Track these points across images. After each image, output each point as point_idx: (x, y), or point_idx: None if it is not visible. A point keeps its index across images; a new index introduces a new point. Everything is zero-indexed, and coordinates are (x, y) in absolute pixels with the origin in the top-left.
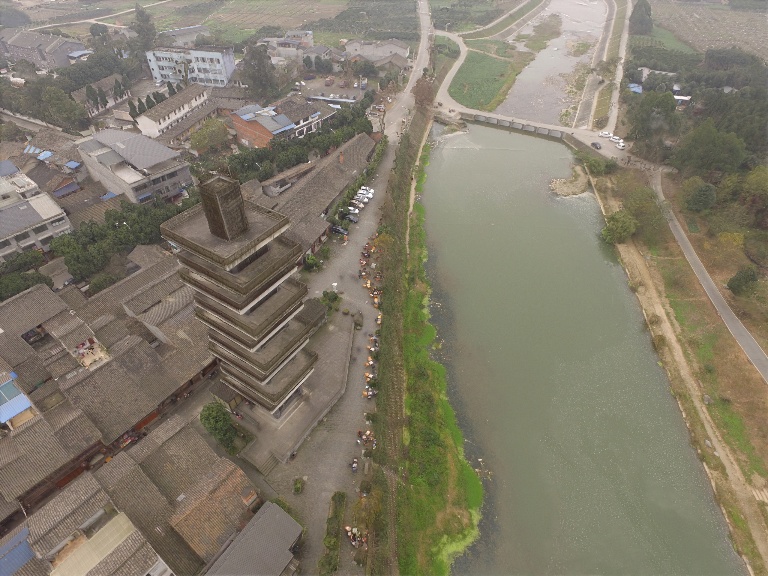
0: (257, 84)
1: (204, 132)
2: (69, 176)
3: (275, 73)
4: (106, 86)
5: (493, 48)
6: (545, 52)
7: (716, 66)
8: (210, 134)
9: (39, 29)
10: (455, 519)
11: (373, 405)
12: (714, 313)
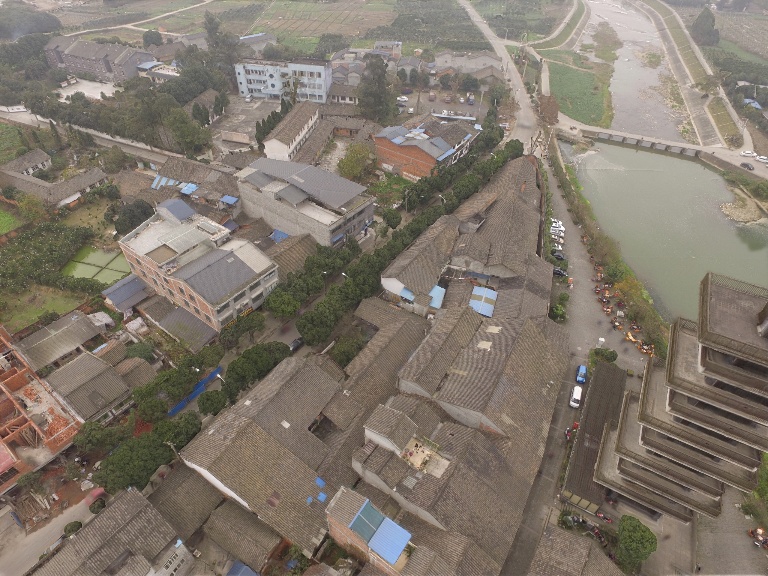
0: (376, 101)
1: (354, 158)
2: (226, 213)
3: None
4: (206, 103)
5: (569, 59)
6: (619, 63)
7: None
8: (361, 160)
9: (75, 35)
10: None
11: (738, 493)
12: None
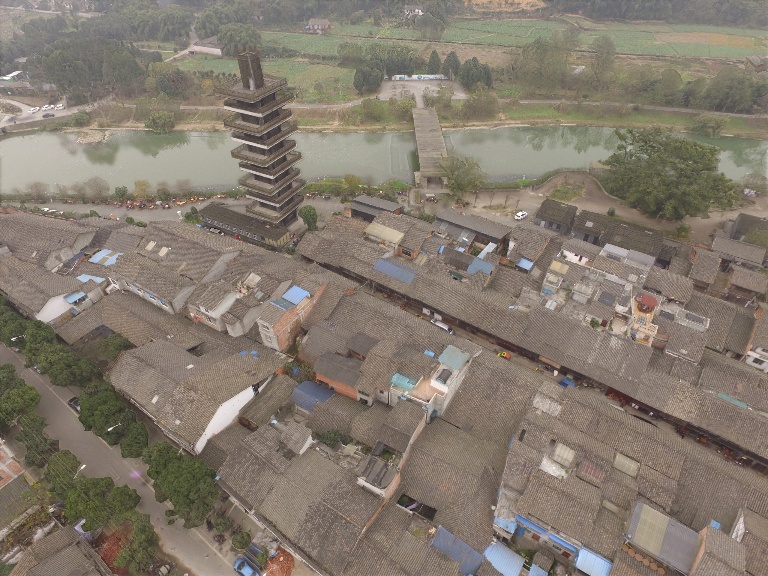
0: None
1: None
2: None
3: None
4: None
5: None
6: None
7: None
8: None
9: None
10: (347, 184)
11: None
12: None
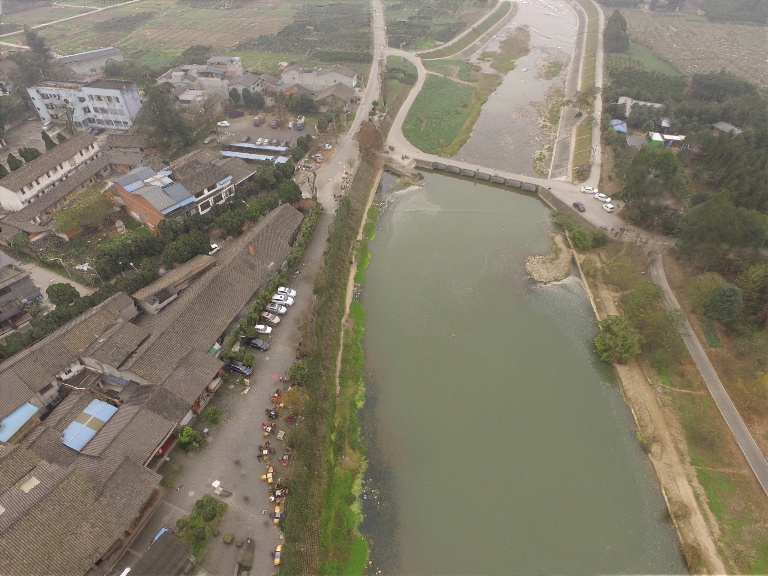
0: (161, 132)
1: (73, 210)
2: None
3: (190, 112)
4: None
5: (455, 70)
6: (513, 74)
7: (705, 94)
8: (82, 212)
9: None
10: None
11: None
12: (764, 501)
